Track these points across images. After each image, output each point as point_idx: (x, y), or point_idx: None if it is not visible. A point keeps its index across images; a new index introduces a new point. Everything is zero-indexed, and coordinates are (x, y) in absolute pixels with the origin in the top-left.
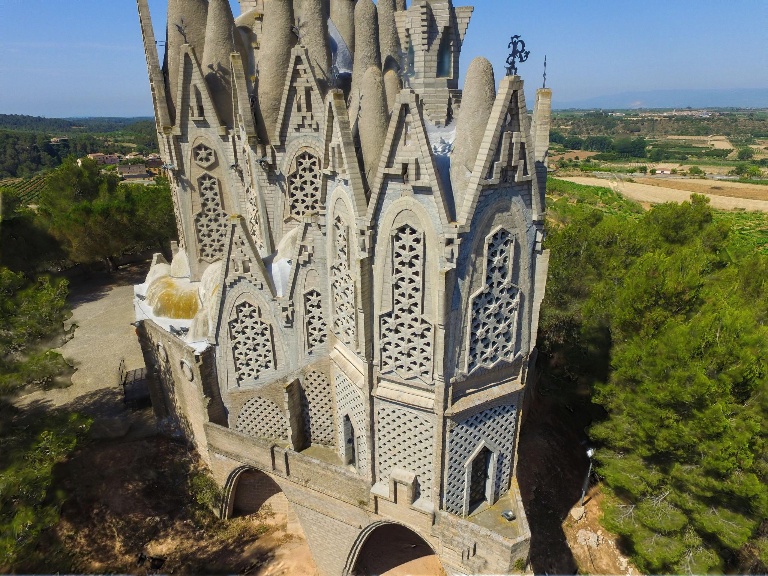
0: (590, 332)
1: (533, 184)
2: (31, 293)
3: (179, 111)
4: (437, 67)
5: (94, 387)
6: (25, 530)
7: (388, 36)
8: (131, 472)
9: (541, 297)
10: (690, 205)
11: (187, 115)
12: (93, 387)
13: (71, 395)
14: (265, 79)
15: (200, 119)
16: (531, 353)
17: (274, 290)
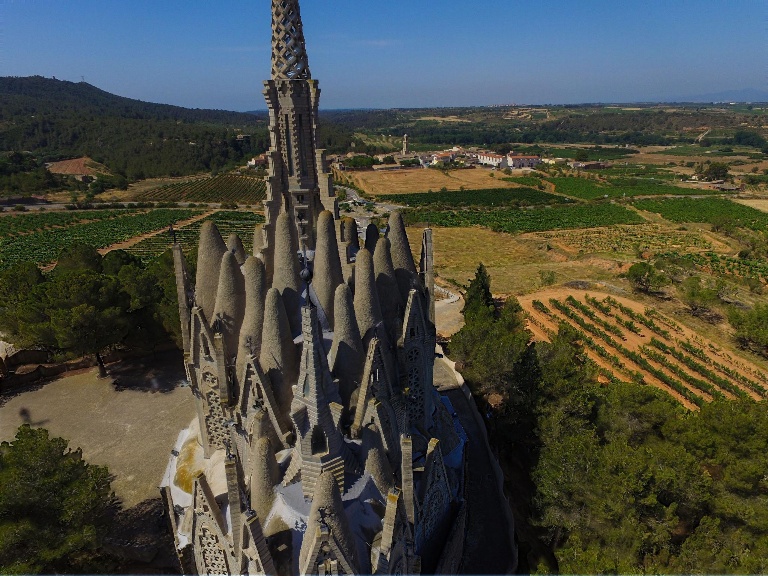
0: None
1: None
2: (78, 485)
3: (192, 349)
4: (314, 446)
5: (152, 495)
6: None
7: (341, 326)
8: None
9: None
10: (766, 408)
11: (198, 351)
12: (151, 495)
13: (135, 500)
14: (241, 353)
15: (206, 357)
16: (514, 560)
17: (226, 528)
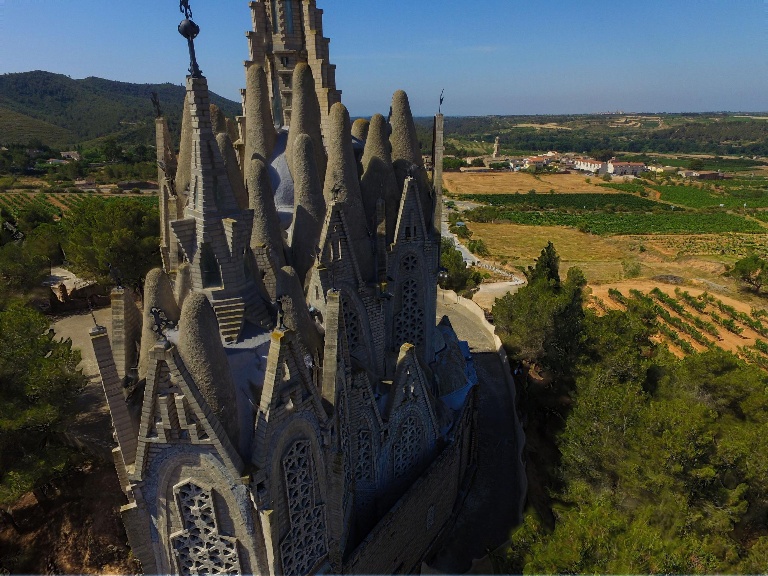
0: (512, 567)
1: (217, 448)
2: None
3: (164, 229)
4: (207, 277)
5: None
6: None
7: (299, 186)
8: (117, 500)
9: (272, 556)
10: None
11: None
12: None
13: None
14: None
15: None
16: None
17: None
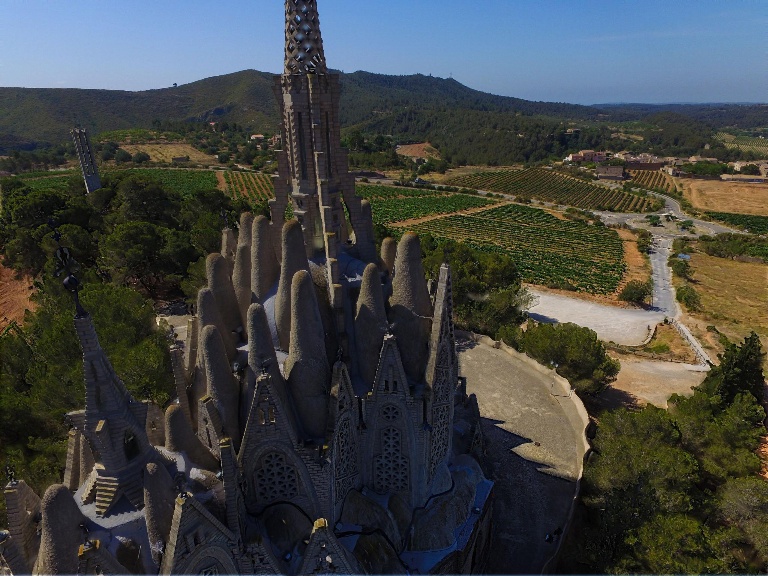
0: None
1: None
2: None
3: None
4: None
5: None
6: None
7: (249, 348)
8: None
9: None
10: None
11: None
12: None
13: None
14: None
15: None
16: None
17: None
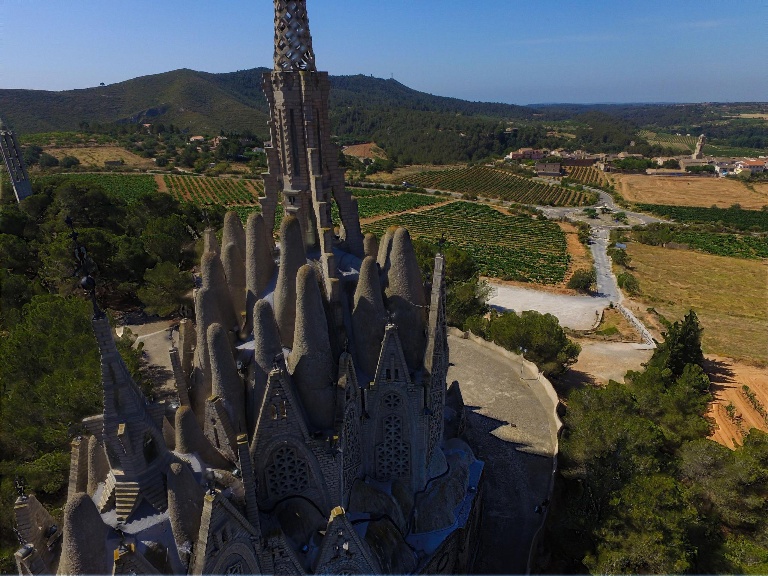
0: None
1: None
2: None
3: None
4: None
5: None
6: (2, 560)
7: (256, 345)
8: None
9: None
10: None
11: None
12: None
13: None
14: None
15: None
16: None
17: None
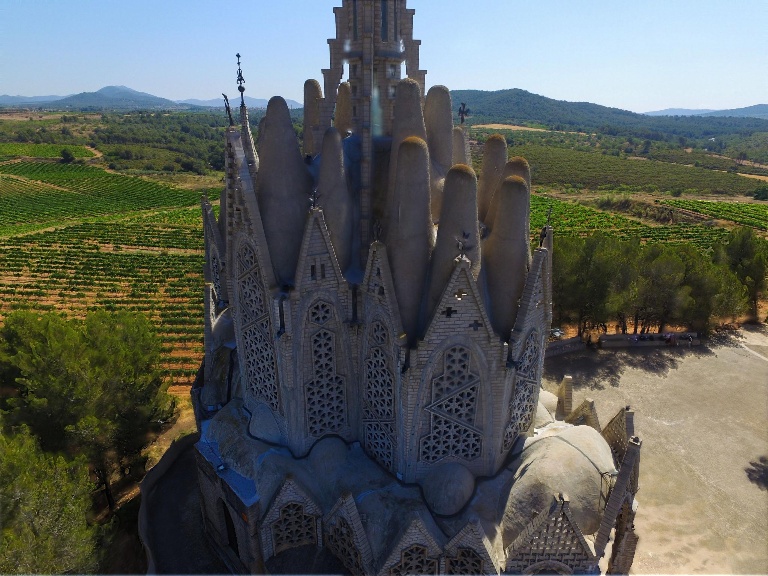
0: None
1: None
2: None
3: None
4: None
5: None
6: None
7: None
8: None
9: None
10: None
11: None
12: None
13: None
14: None
15: None
16: None
17: None
